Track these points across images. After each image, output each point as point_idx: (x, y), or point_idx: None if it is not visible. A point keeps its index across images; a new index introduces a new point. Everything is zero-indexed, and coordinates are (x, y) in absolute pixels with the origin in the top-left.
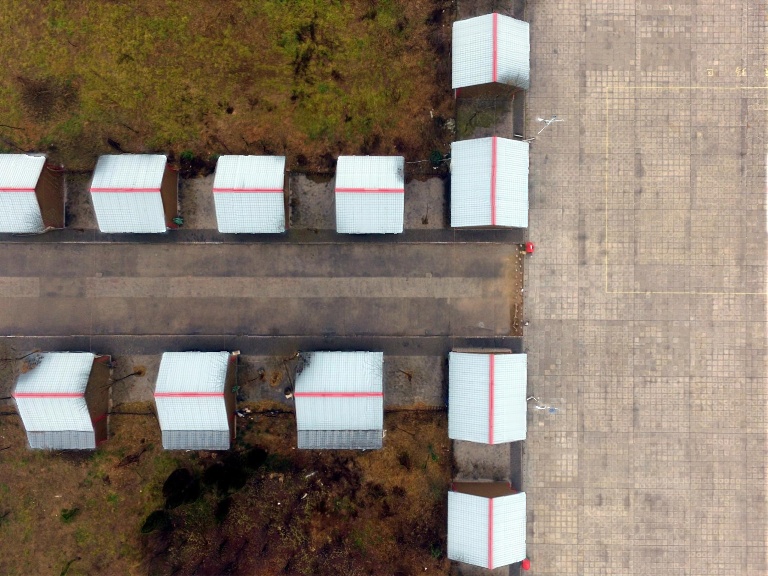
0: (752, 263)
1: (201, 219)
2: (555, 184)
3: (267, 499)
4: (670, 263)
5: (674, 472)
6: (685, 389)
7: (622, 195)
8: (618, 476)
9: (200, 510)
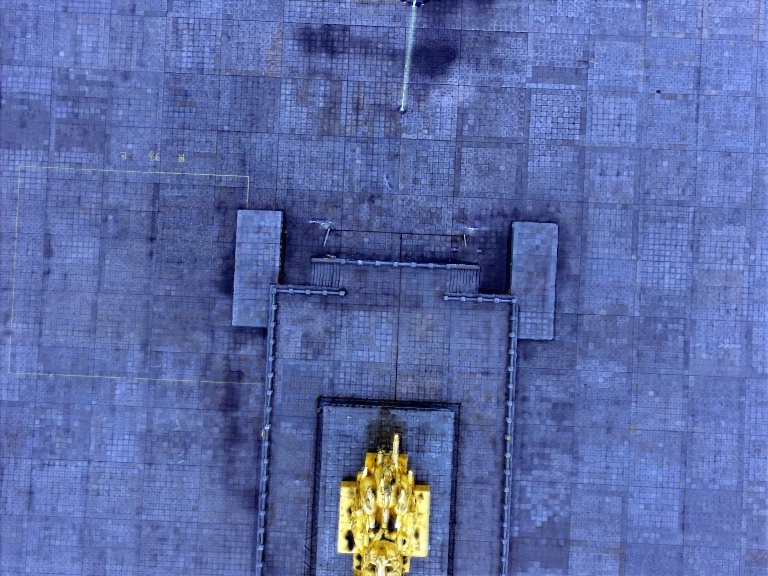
0: (157, 349)
1: None
2: None
3: None
4: (75, 345)
5: (66, 557)
6: (83, 473)
7: (30, 275)
8: (10, 559)
9: None
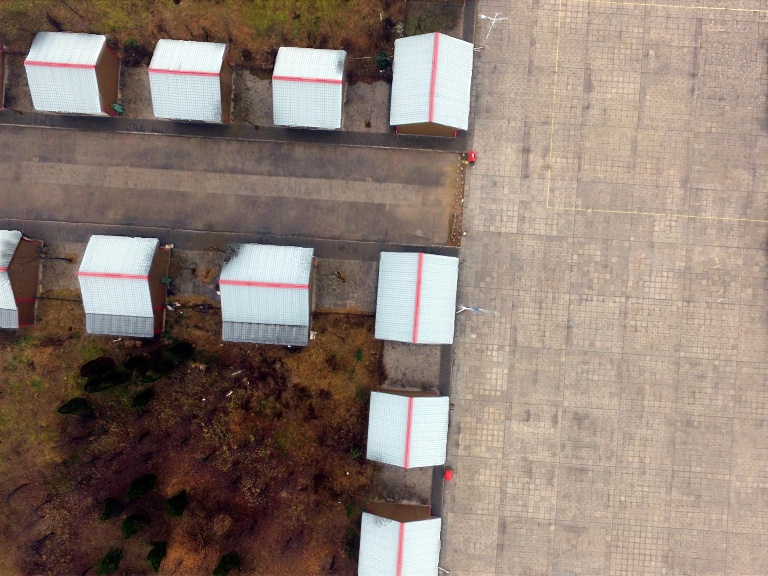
0: (696, 186)
1: (141, 109)
2: (502, 95)
3: (192, 394)
4: (613, 181)
5: (604, 392)
6: (621, 309)
7: (569, 110)
8: (548, 393)
9: (124, 401)
